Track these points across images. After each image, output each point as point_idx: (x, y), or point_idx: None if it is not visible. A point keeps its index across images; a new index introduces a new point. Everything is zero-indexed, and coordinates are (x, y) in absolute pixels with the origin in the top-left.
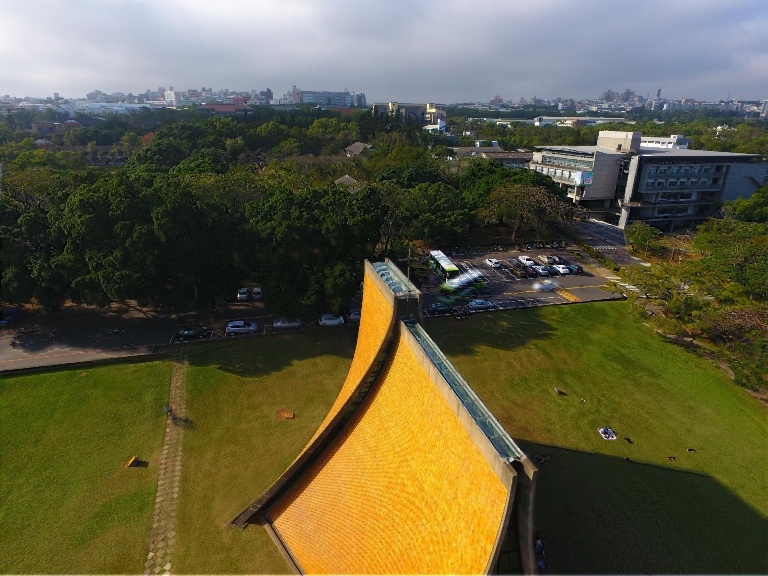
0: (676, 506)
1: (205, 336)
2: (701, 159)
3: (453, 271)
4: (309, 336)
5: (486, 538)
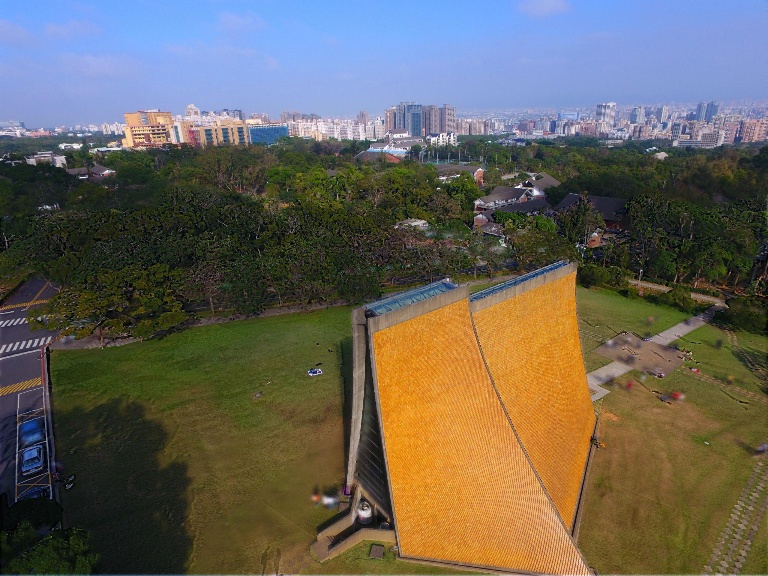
0: None
1: None
2: None
3: None
4: None
5: None
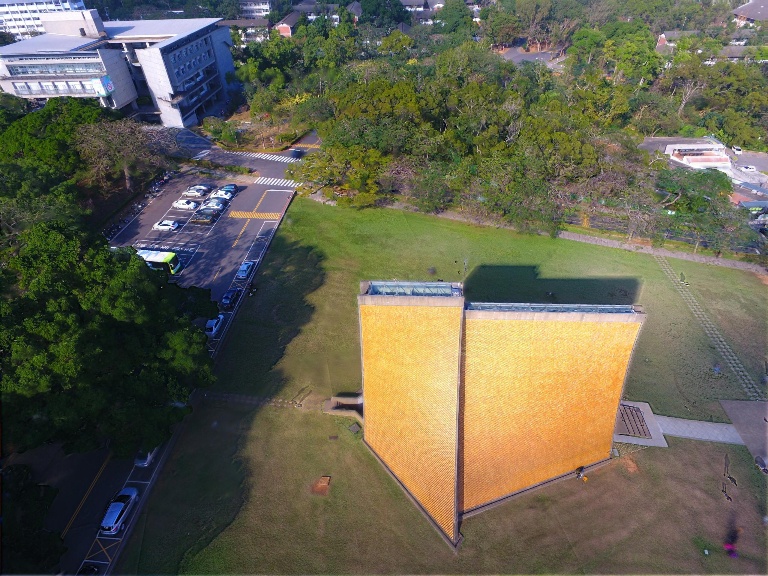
0: (492, 291)
1: (98, 571)
2: (191, 35)
3: (173, 258)
4: (193, 431)
5: (626, 351)
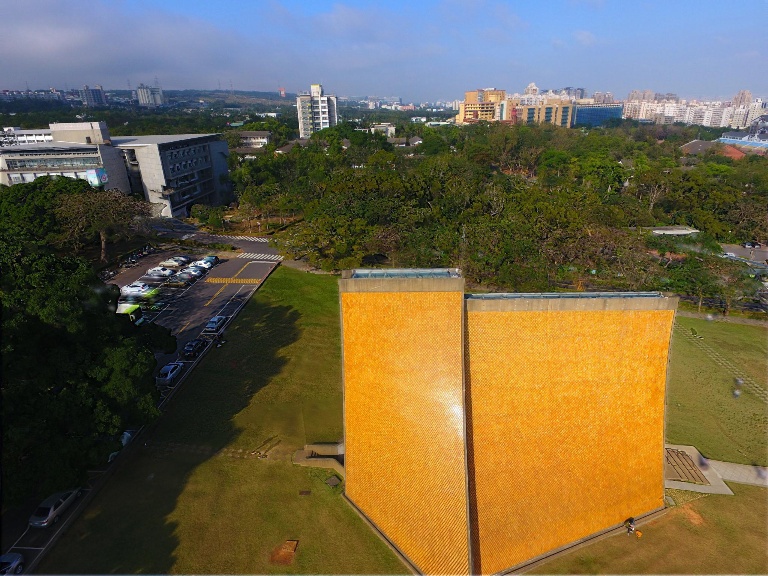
0: None
1: None
2: None
3: (135, 310)
4: (120, 484)
5: (661, 350)
